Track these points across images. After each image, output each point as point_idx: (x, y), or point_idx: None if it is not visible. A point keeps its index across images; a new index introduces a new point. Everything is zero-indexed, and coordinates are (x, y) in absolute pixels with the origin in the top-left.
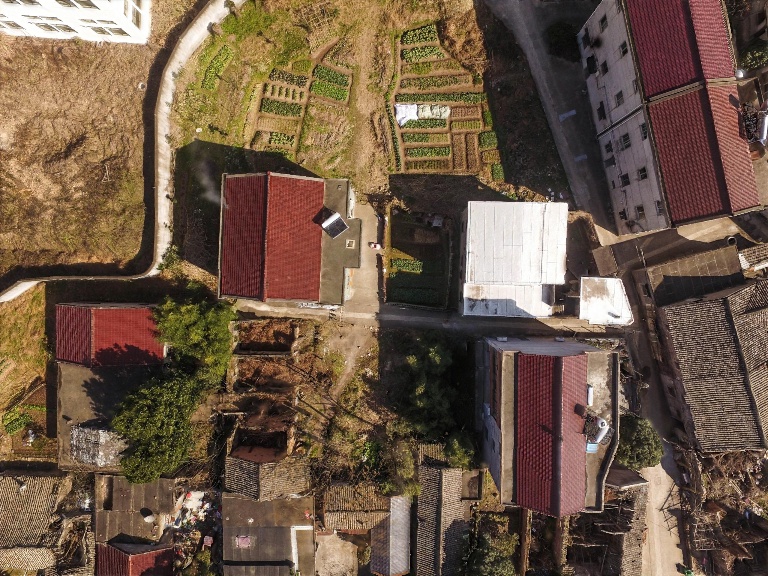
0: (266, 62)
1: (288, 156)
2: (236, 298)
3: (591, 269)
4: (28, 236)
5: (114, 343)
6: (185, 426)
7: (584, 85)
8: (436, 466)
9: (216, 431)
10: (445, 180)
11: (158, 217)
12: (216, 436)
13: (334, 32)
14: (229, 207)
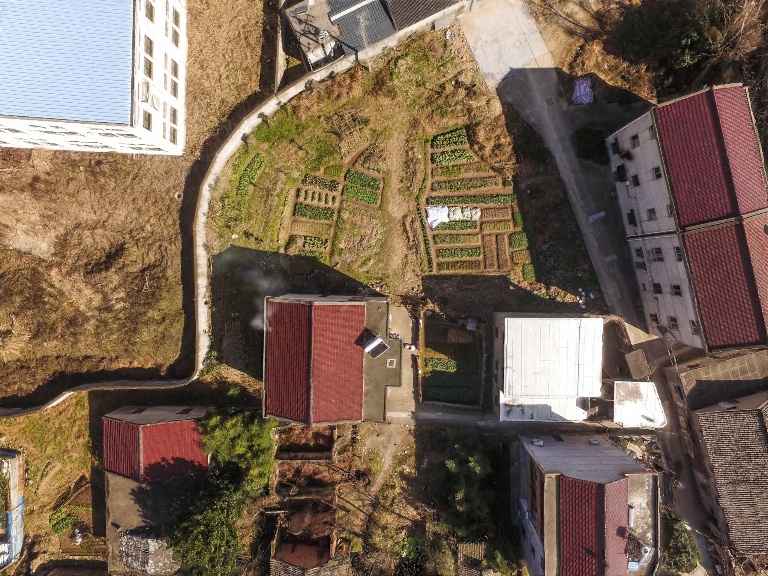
0: (299, 168)
1: (322, 260)
2: (282, 420)
3: (622, 366)
4: (71, 345)
5: (161, 457)
6: (234, 542)
7: (613, 187)
8: (476, 567)
9: (258, 530)
10: (477, 280)
11: (199, 328)
12: (259, 535)
13: (365, 138)
14: (272, 330)
